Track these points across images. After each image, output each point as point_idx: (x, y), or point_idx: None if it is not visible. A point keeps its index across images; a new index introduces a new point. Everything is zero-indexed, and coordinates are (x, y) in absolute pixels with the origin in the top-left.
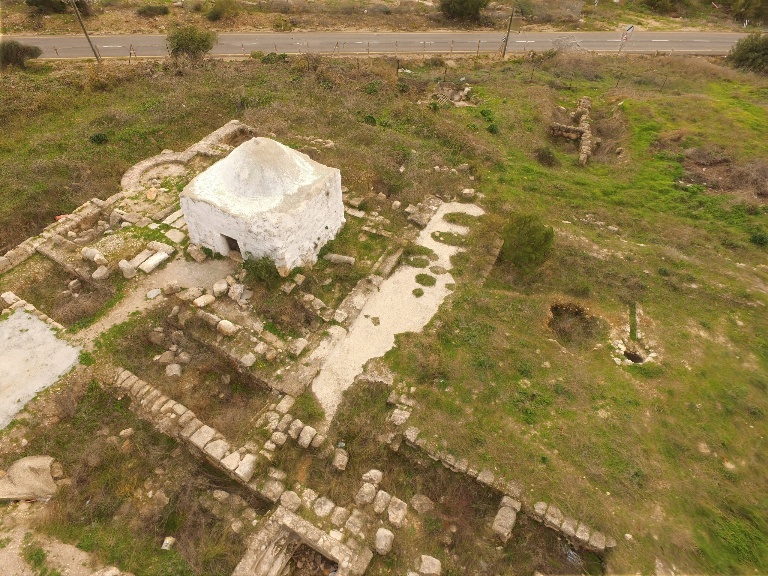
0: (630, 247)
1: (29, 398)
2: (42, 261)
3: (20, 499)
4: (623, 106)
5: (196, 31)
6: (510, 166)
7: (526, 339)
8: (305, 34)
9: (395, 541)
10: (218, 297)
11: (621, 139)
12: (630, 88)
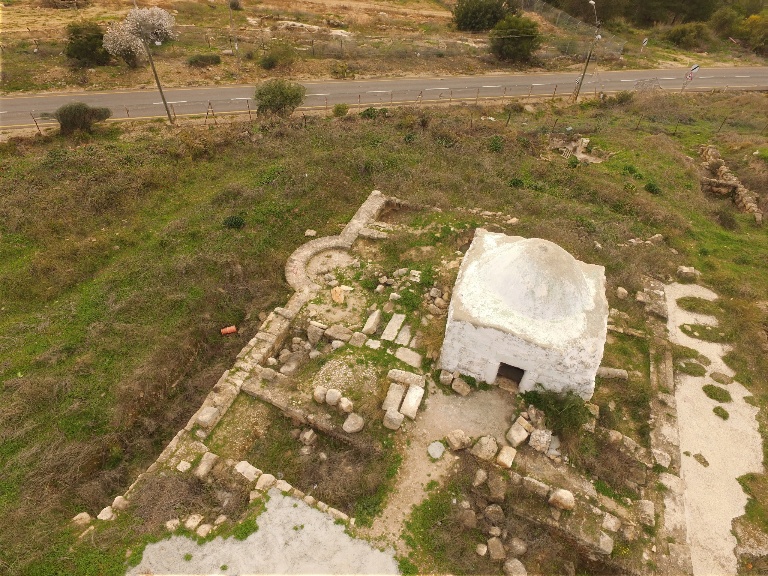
0: None
1: None
2: (253, 405)
3: None
4: (765, 156)
5: (285, 86)
6: (701, 233)
7: None
8: (370, 81)
9: None
10: (517, 448)
11: None
12: (732, 132)
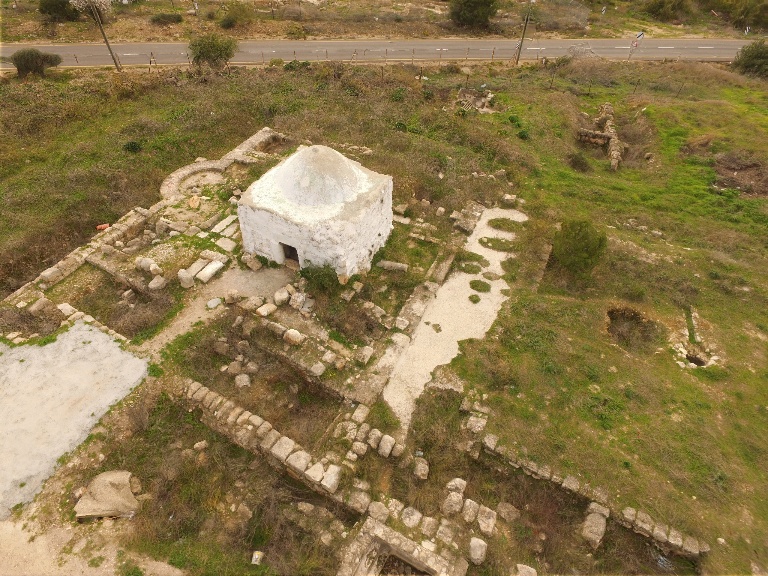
0: (678, 251)
1: (103, 412)
2: (93, 271)
3: (103, 516)
4: (648, 112)
5: (218, 39)
6: (546, 172)
7: (589, 344)
8: (320, 42)
9: (488, 550)
10: (279, 306)
11: (649, 144)
12: (647, 94)
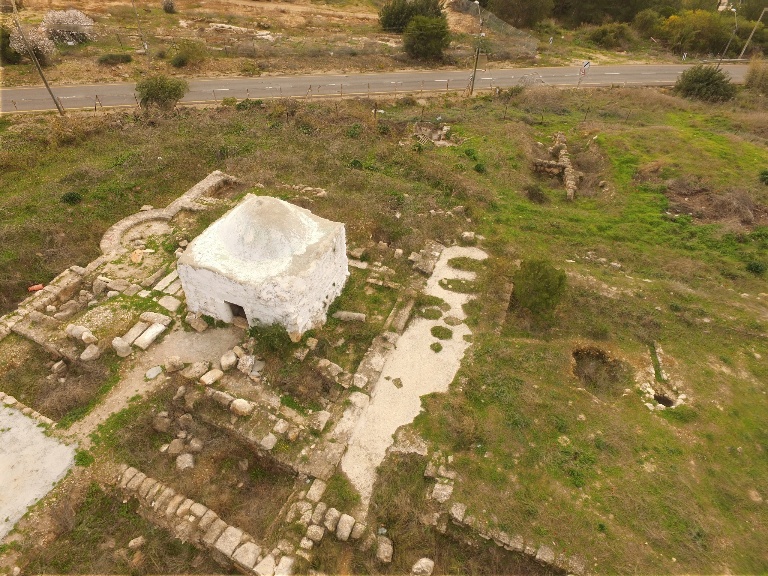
0: (638, 284)
1: (19, 515)
2: (19, 342)
3: None
4: (599, 140)
5: (166, 80)
6: (503, 205)
7: (555, 390)
8: (275, 78)
9: None
10: (226, 371)
11: (602, 172)
12: (597, 121)
